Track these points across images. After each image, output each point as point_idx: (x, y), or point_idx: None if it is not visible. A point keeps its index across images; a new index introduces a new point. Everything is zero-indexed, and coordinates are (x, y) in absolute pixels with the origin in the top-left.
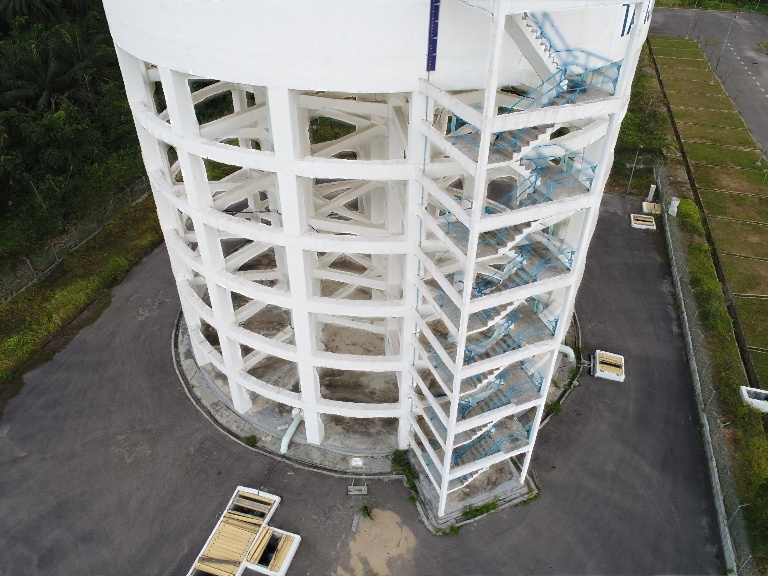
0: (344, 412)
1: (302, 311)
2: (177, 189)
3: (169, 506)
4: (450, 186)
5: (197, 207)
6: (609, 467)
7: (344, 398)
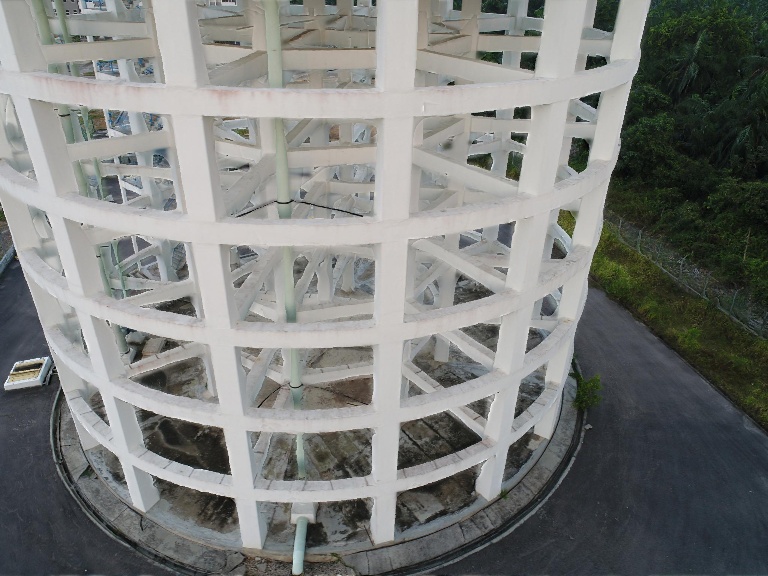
0: None
1: None
2: None
3: None
4: None
5: None
6: None
7: (297, 273)
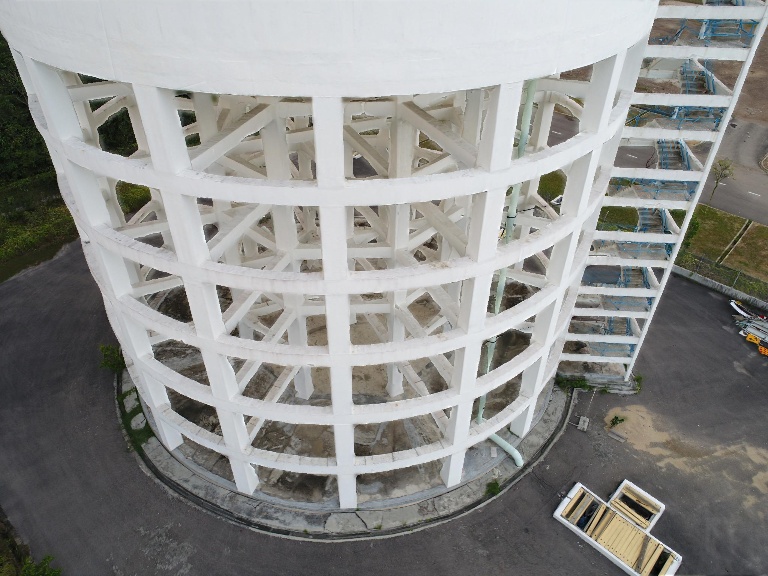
0: (551, 374)
1: (562, 293)
2: (425, 265)
3: None
4: None
5: (493, 255)
6: None
7: None
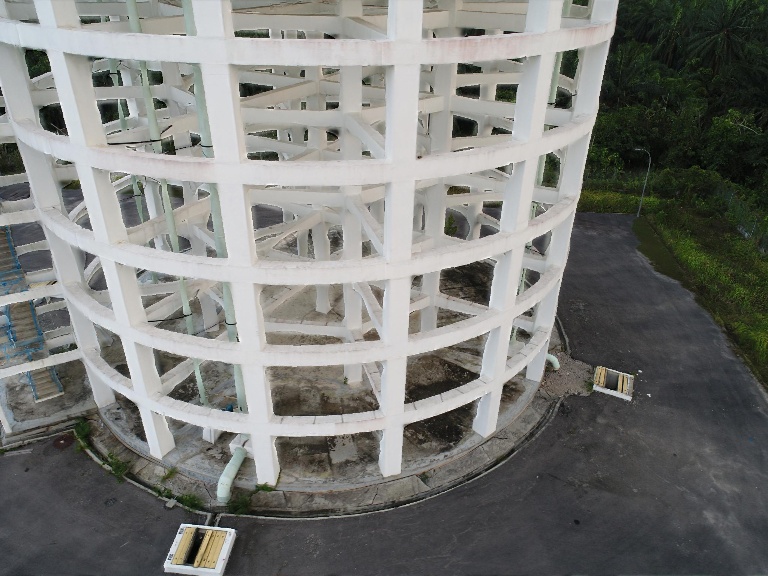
0: None
1: None
2: None
3: (86, 260)
4: (688, 360)
5: None
6: (2, 531)
7: None
